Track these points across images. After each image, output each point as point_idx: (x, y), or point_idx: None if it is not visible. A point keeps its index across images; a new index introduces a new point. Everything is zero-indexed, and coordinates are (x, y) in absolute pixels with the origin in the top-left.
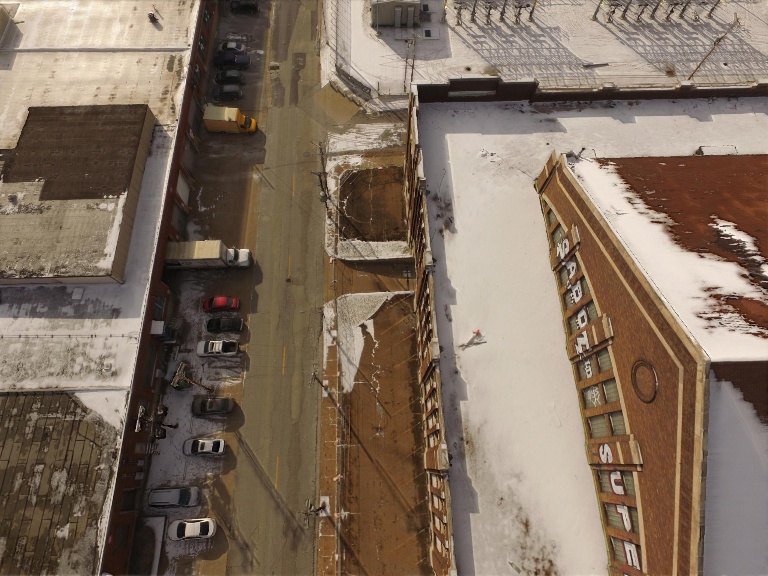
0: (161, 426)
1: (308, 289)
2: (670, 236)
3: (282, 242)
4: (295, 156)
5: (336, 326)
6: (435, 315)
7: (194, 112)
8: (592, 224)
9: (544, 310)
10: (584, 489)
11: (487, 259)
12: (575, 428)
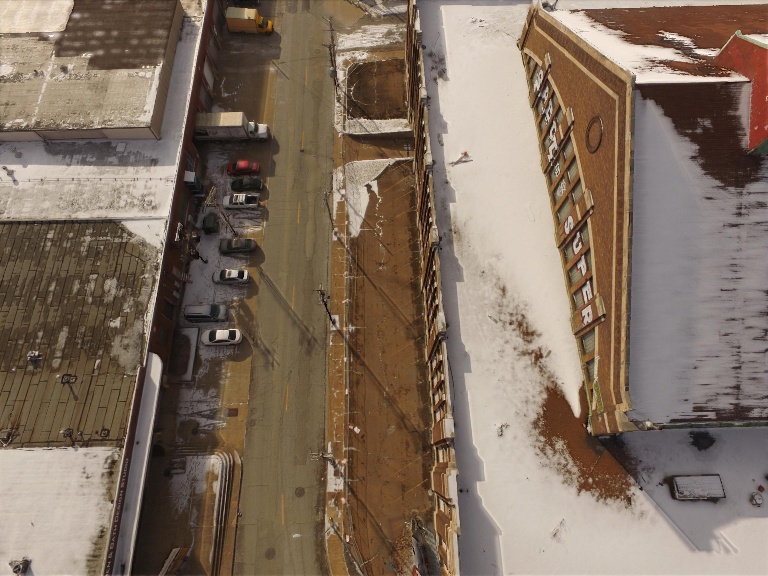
0: (193, 262)
1: (319, 158)
2: (622, 39)
3: (296, 121)
4: (307, 53)
5: (344, 186)
6: (429, 136)
7: (217, 13)
8: (559, 40)
9: (523, 137)
10: (553, 265)
11: (475, 100)
12: (547, 222)
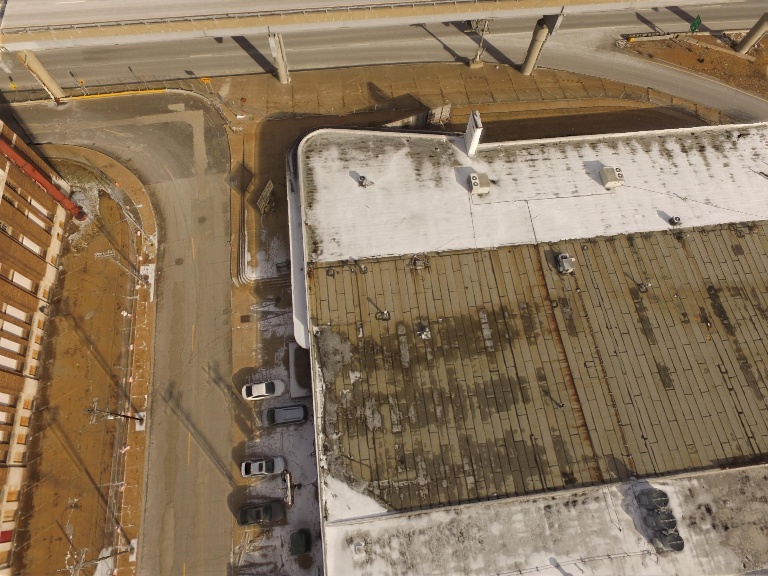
0: None
1: None
2: None
3: None
4: None
5: None
6: None
7: None
8: None
9: None
10: None
11: None
12: None
